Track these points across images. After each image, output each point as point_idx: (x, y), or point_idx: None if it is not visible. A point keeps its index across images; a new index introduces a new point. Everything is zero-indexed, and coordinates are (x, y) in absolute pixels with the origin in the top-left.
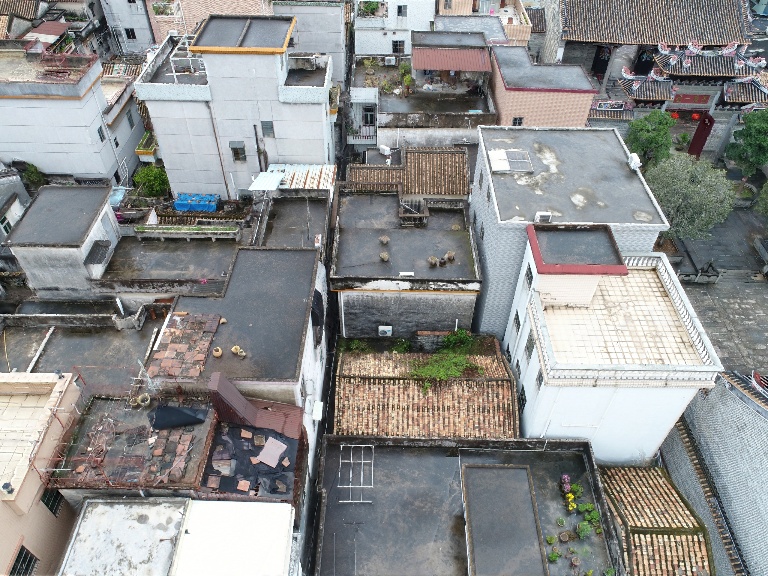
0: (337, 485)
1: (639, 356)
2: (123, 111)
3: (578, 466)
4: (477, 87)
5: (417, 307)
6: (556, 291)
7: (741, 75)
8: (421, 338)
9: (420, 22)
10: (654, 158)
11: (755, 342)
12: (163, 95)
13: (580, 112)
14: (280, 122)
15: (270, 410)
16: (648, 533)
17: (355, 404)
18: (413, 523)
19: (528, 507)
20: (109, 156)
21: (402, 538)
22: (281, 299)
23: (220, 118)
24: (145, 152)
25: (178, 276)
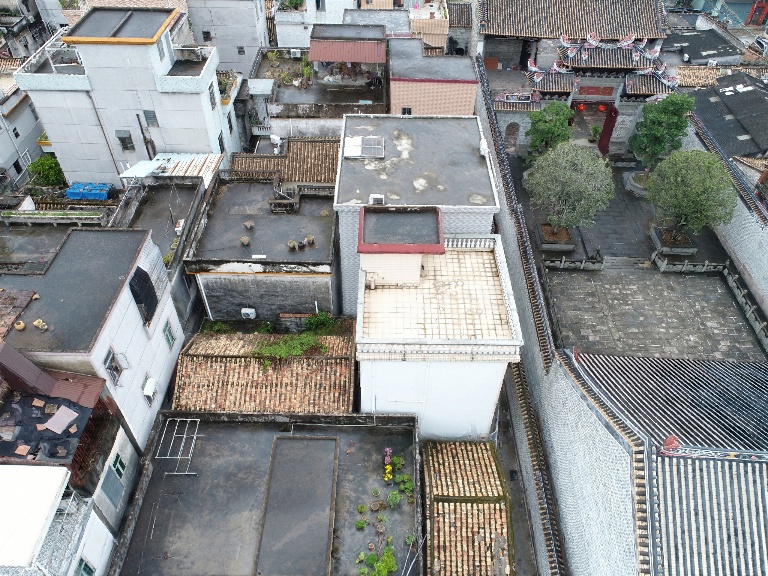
0: (155, 456)
1: (454, 332)
2: (24, 102)
3: (405, 440)
4: (377, 79)
5: (275, 290)
6: (383, 270)
7: (639, 67)
8: (284, 320)
9: (339, 16)
10: (552, 148)
11: (628, 326)
12: (43, 85)
13: (466, 102)
14: (162, 111)
15: (70, 381)
16: (452, 501)
17: (196, 381)
18: (233, 493)
19: (328, 475)
20: (6, 146)
21: (219, 507)
22: (99, 276)
23: (103, 108)
24: (46, 143)
25: (37, 259)
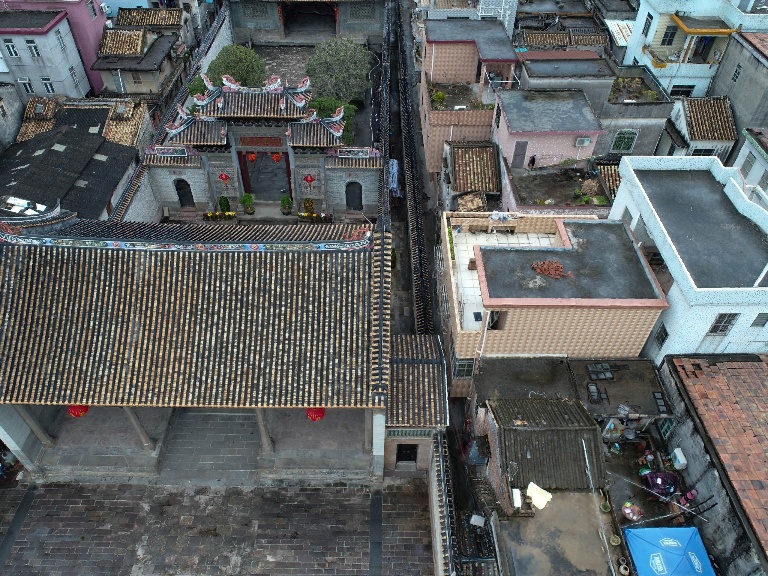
0: None
1: None
2: None
3: None
4: None
5: None
6: None
7: None
8: None
9: None
10: None
11: None
12: None
13: None
14: None
15: None
16: None
17: None
18: None
19: None
20: None
21: None
22: None
23: None
24: None
25: None
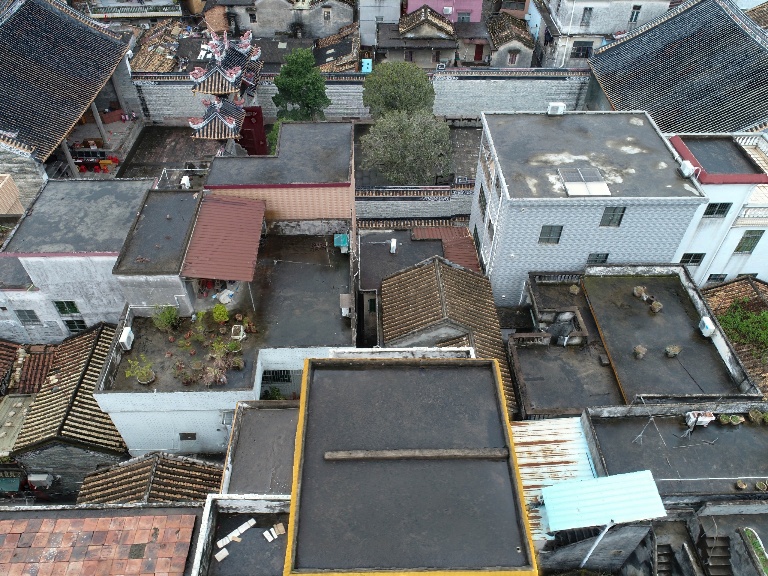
0: None
1: None
2: None
3: None
4: None
5: None
6: None
7: (250, 55)
8: None
9: None
10: None
11: None
12: None
13: None
14: None
15: None
16: None
17: None
18: None
19: None
20: None
21: None
22: None
23: None
24: None
25: None
